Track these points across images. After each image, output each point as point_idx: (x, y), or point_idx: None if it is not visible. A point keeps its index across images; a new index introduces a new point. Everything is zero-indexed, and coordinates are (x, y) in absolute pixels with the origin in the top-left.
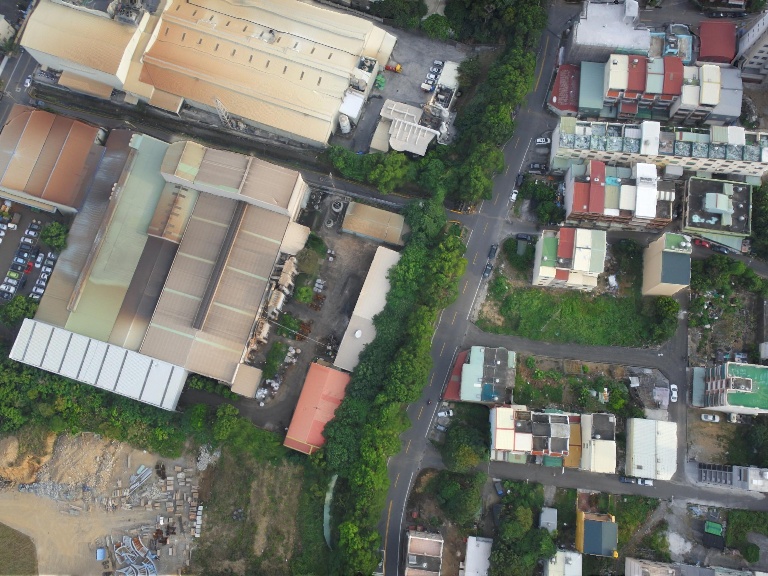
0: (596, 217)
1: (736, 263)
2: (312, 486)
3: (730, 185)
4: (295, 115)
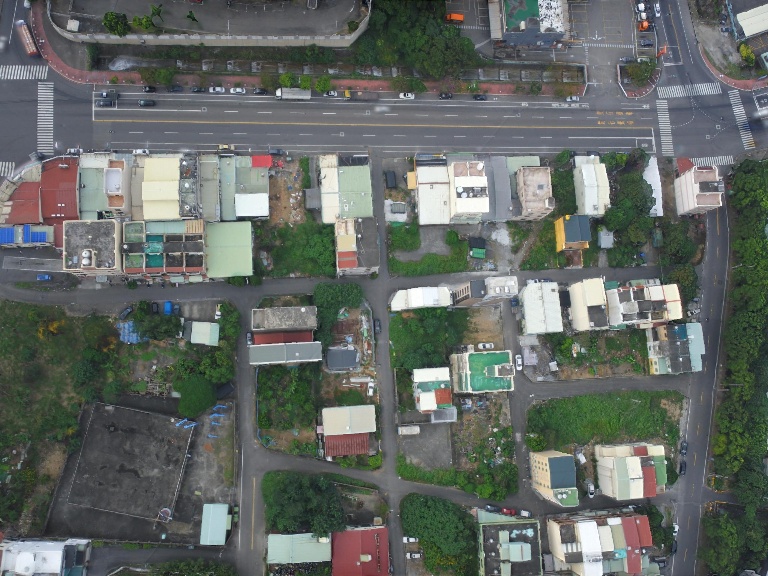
0: None
1: None
2: None
3: (505, 575)
4: None
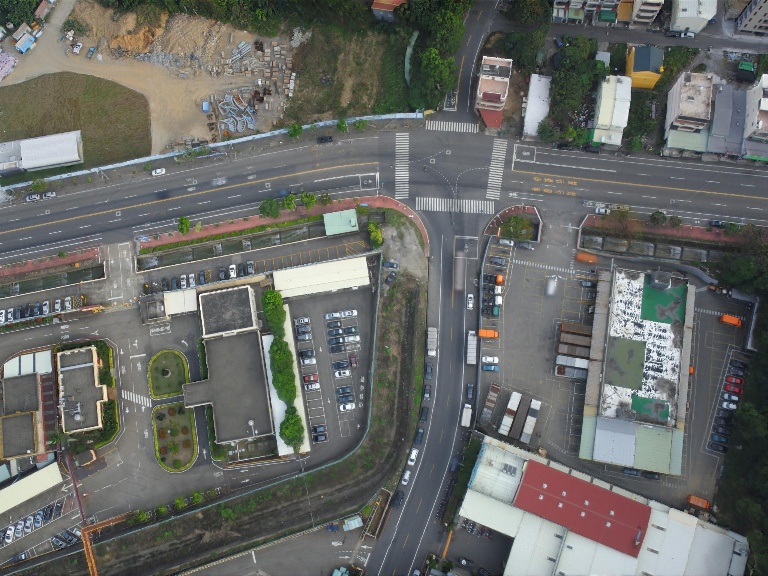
0: None
1: None
2: (398, 28)
3: None
4: None
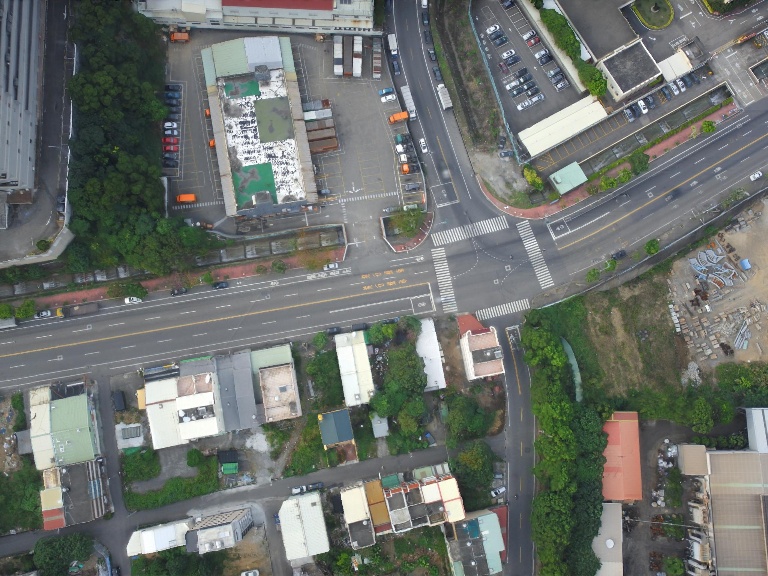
0: None
1: None
2: None
3: None
4: None
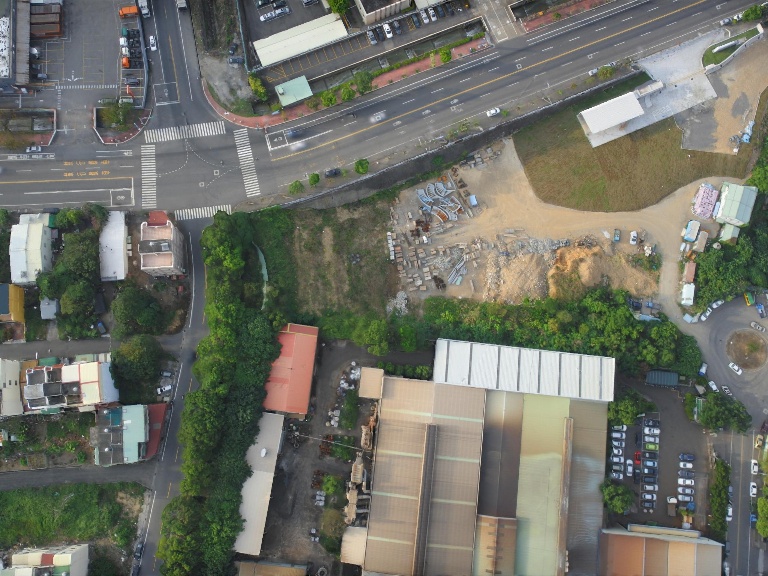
0: None
1: None
2: None
3: None
4: None
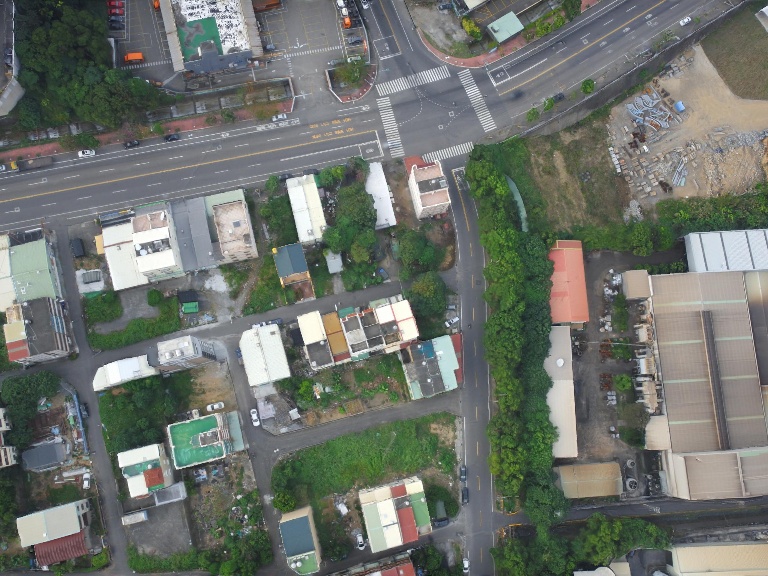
0: (383, 569)
1: (233, 571)
2: None
3: None
4: (720, 567)
